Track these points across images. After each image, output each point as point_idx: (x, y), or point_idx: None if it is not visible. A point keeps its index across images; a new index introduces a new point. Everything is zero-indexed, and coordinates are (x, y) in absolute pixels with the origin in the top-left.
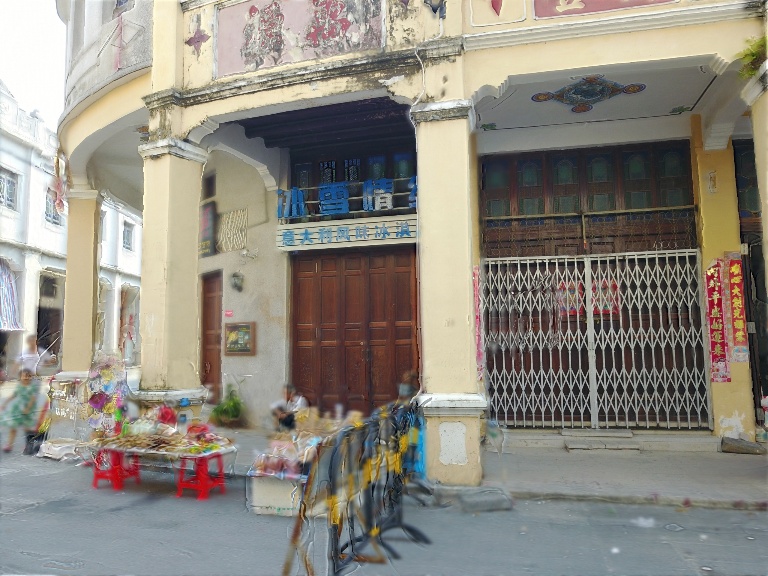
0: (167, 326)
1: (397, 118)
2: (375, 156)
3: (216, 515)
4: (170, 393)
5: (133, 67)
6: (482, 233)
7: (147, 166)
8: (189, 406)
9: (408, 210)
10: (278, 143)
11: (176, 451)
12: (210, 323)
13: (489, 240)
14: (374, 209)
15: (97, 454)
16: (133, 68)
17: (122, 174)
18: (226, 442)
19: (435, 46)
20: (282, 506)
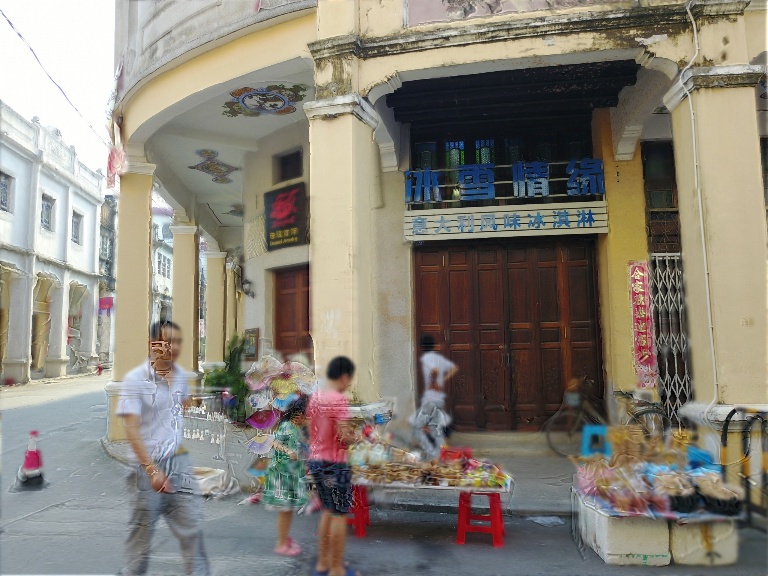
0: (356, 325)
1: (564, 94)
2: (512, 137)
3: (558, 568)
4: (364, 408)
5: (289, 7)
6: (647, 226)
7: (316, 128)
8: (377, 423)
9: (566, 198)
10: (410, 116)
11: (465, 485)
12: (286, 324)
13: (655, 233)
14: (526, 195)
15: (341, 491)
16: (289, 8)
17: (175, 147)
18: (497, 470)
19: (717, 1)
20: (649, 553)
